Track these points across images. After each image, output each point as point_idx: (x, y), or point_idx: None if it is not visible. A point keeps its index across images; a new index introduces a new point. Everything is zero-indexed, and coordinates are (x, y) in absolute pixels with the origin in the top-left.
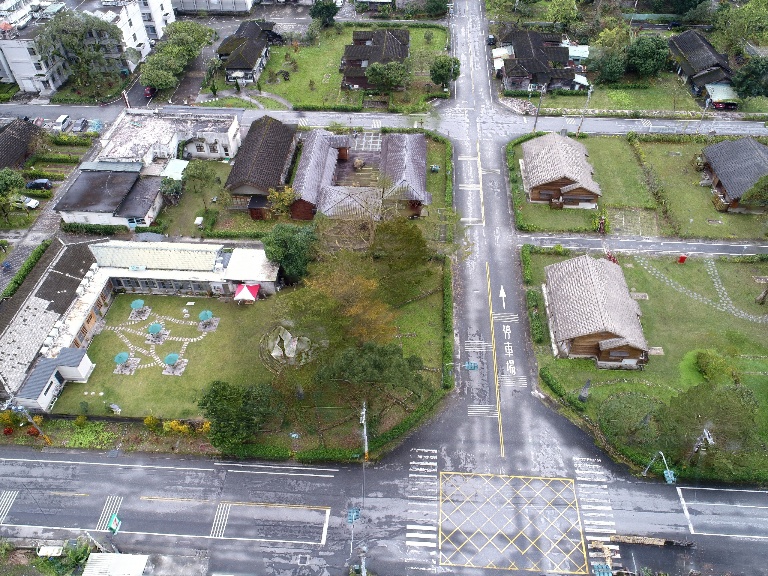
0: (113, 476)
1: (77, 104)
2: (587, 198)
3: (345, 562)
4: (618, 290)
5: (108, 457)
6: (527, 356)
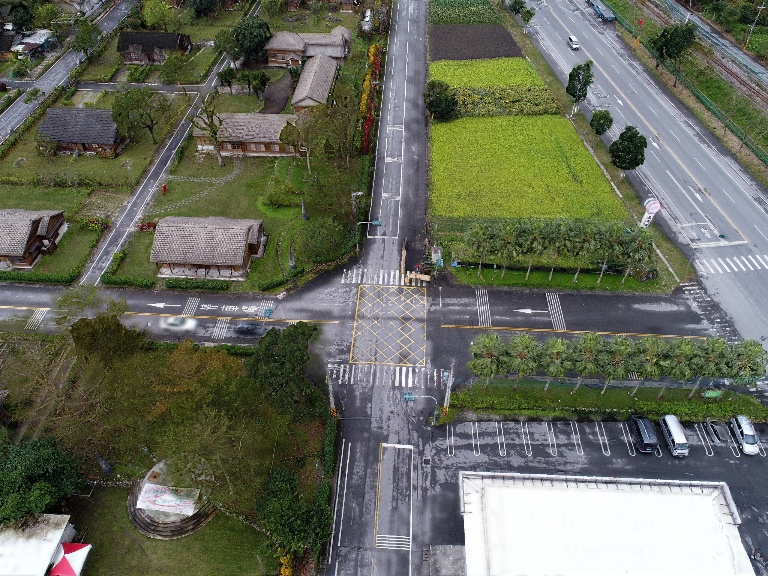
0: None
1: None
2: (60, 222)
3: (427, 430)
4: (199, 220)
5: None
6: (240, 297)
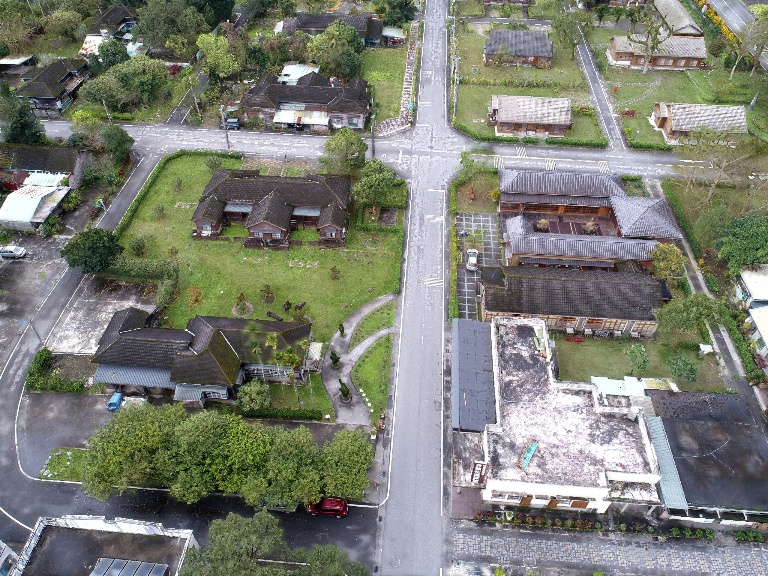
0: None
1: None
2: None
3: None
4: None
5: None
6: None
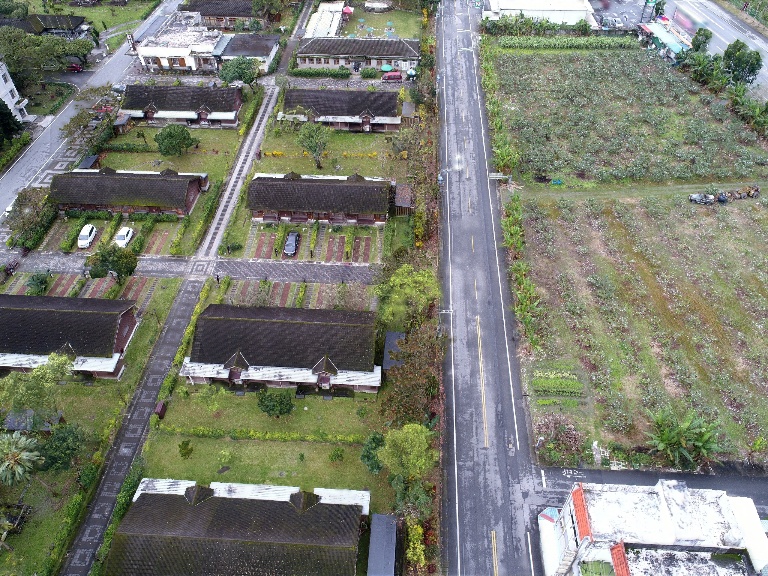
0: (448, 32)
1: (68, 101)
2: None
3: None
4: None
5: (440, 34)
6: None
